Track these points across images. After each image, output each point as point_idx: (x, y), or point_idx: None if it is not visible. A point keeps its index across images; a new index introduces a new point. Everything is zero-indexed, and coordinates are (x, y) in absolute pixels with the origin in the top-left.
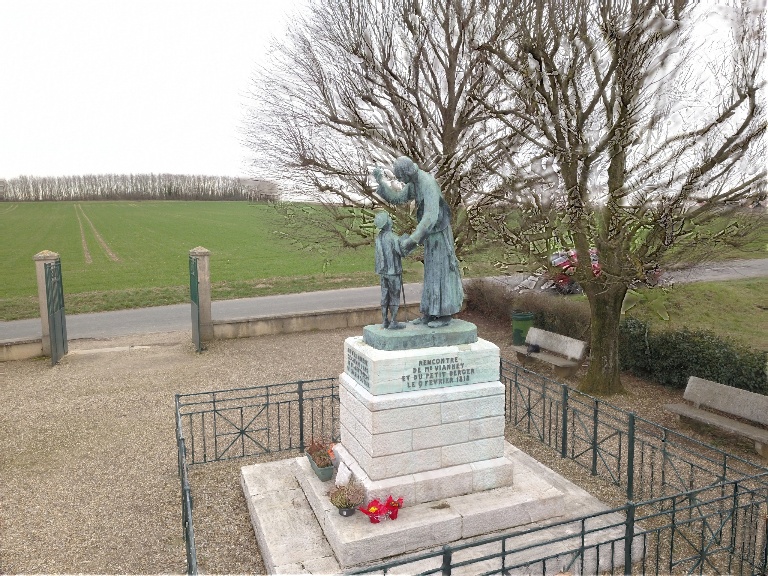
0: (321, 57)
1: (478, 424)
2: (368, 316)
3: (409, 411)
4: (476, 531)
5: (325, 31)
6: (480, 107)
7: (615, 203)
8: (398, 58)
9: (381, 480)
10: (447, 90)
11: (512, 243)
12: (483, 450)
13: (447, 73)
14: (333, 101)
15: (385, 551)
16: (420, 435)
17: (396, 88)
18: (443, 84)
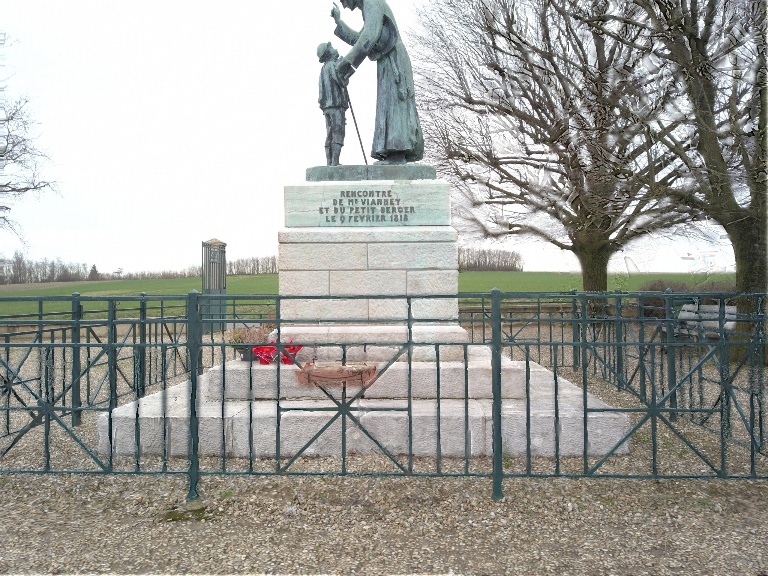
0: (457, 42)
1: (419, 276)
2: (515, 315)
3: (325, 248)
4: (385, 393)
5: (459, 14)
6: (583, 27)
7: (709, 65)
8: (521, 17)
9: (290, 327)
10: (596, 55)
11: (623, 176)
12: (427, 311)
13: (594, 36)
14: (466, 80)
15: (260, 391)
16: (339, 279)
17: (537, 62)
18: (591, 49)
